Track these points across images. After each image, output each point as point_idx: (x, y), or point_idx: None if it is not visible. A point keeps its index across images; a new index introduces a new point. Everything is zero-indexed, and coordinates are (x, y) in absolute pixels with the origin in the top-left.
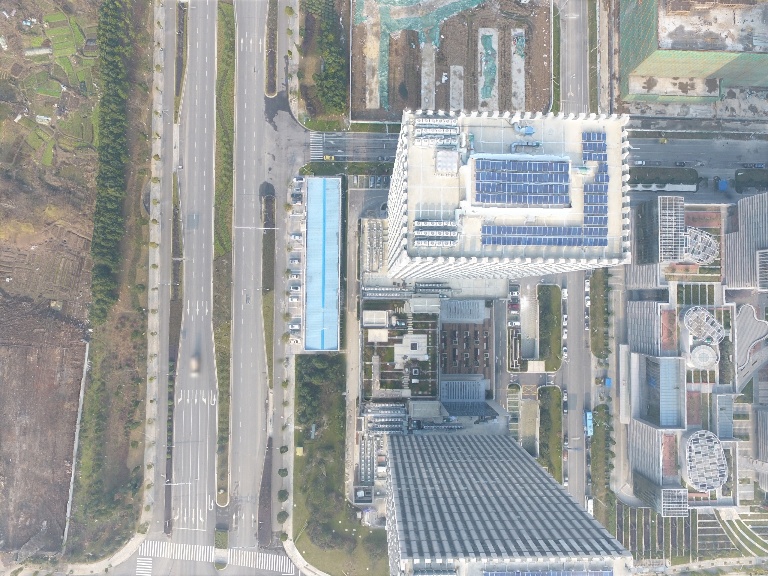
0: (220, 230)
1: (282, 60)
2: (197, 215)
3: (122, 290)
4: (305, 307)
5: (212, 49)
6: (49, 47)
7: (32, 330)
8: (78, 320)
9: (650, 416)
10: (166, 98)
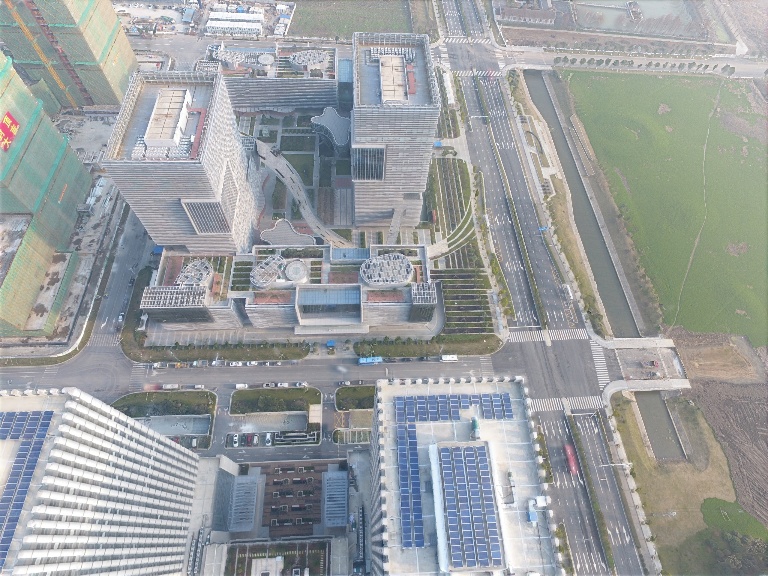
0: None
1: None
2: None
3: None
4: None
5: None
6: None
7: None
8: None
9: (355, 311)
10: None
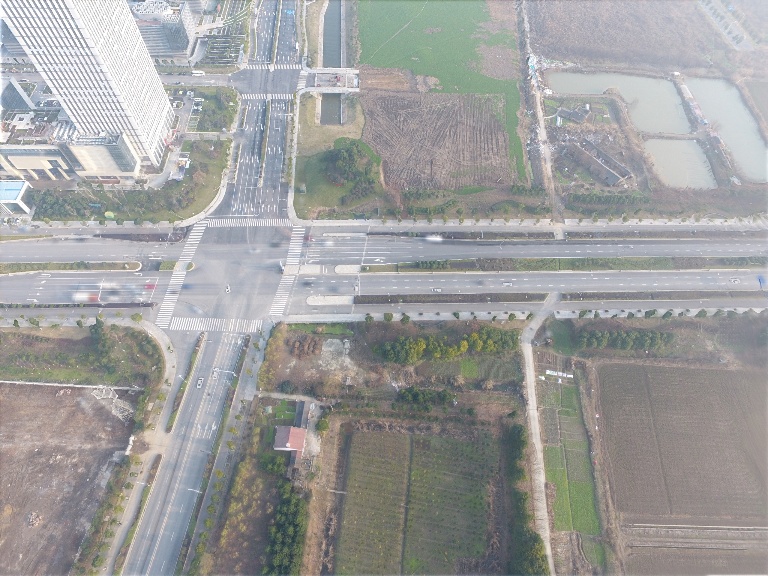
0: None
1: None
2: None
3: None
4: None
5: None
6: None
7: None
8: None
9: None
10: None
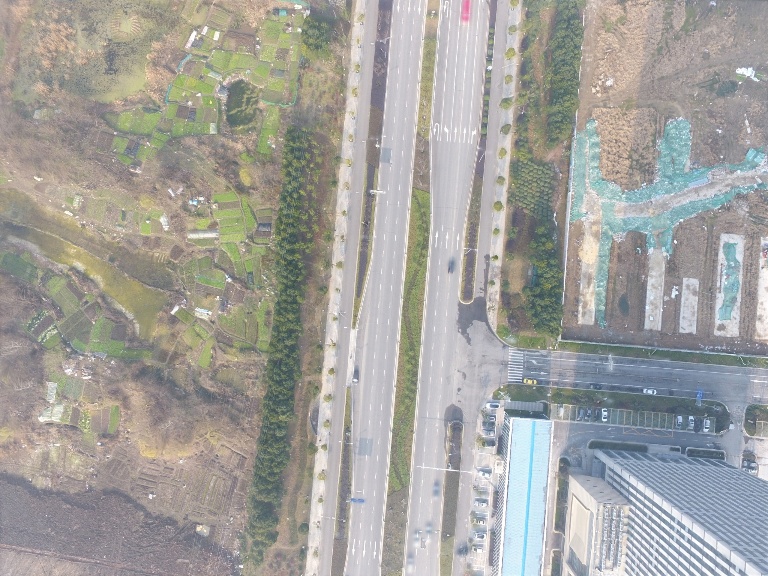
0: (397, 460)
1: (482, 260)
2: (371, 439)
3: (280, 522)
4: (501, 575)
5: (401, 243)
6: (216, 231)
7: (175, 559)
8: (226, 550)
9: None
10: (344, 298)
